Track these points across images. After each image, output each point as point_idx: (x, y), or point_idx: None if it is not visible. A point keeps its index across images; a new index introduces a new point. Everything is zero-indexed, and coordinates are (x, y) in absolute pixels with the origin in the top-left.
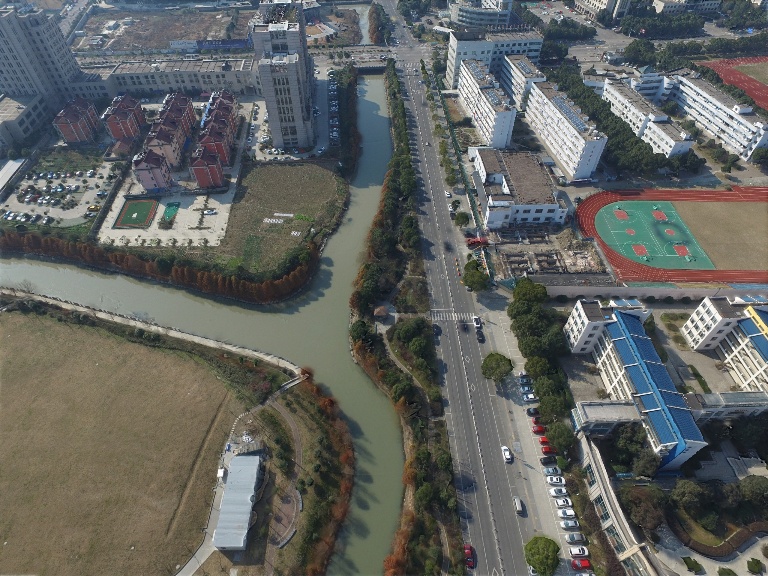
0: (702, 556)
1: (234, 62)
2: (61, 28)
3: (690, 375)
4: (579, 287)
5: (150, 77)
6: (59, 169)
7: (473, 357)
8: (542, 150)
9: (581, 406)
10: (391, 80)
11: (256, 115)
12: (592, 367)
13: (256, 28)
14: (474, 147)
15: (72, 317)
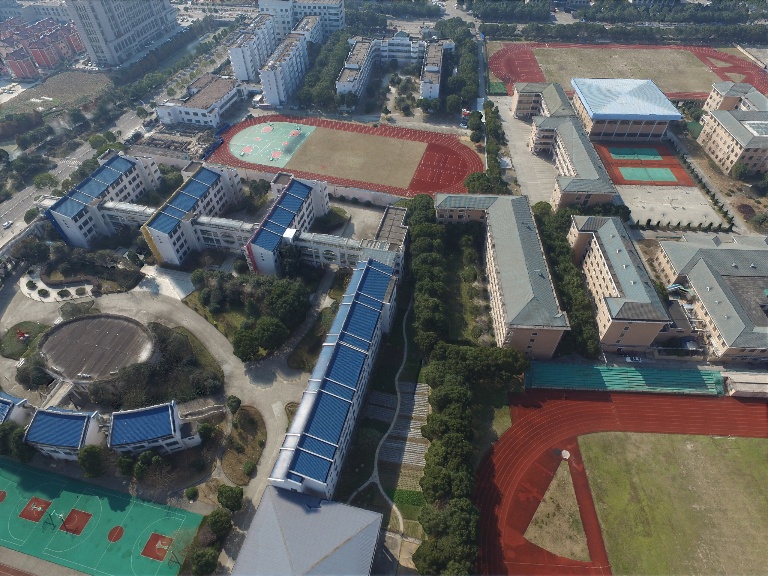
0: (43, 284)
1: None
2: None
3: None
4: (155, 155)
5: (55, 10)
6: None
7: None
8: None
9: (44, 198)
10: None
11: None
12: None
13: None
14: None
15: None
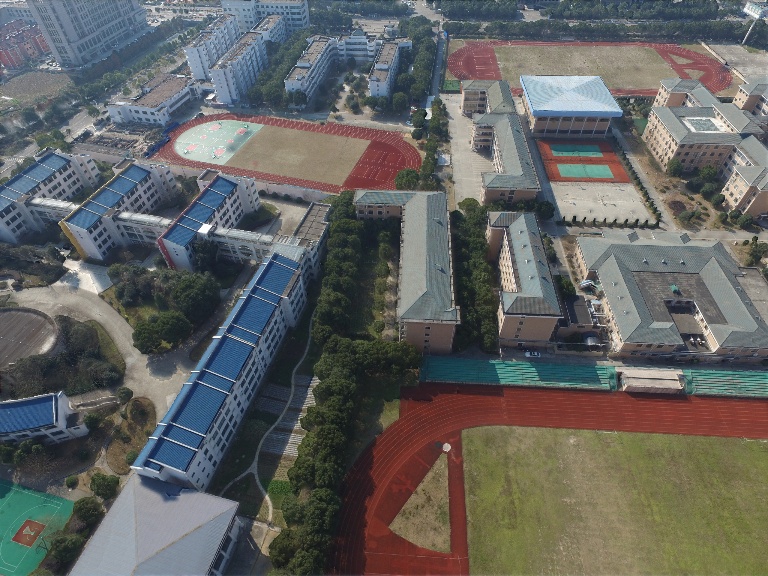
0: None
1: None
2: None
3: None
4: (97, 153)
5: (28, 11)
6: None
7: None
8: None
9: None
10: None
11: None
12: None
13: None
14: None
15: None
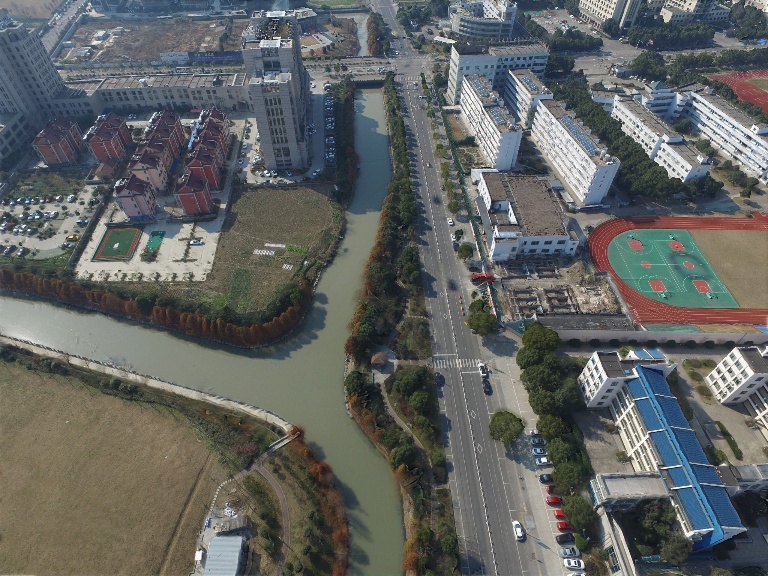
0: None
1: (226, 76)
2: (48, 39)
3: (718, 433)
4: (594, 331)
5: (137, 93)
6: (38, 194)
7: (479, 412)
8: (549, 172)
9: (601, 479)
10: (390, 95)
11: (248, 133)
12: (610, 424)
13: (247, 45)
14: (478, 169)
15: (43, 365)
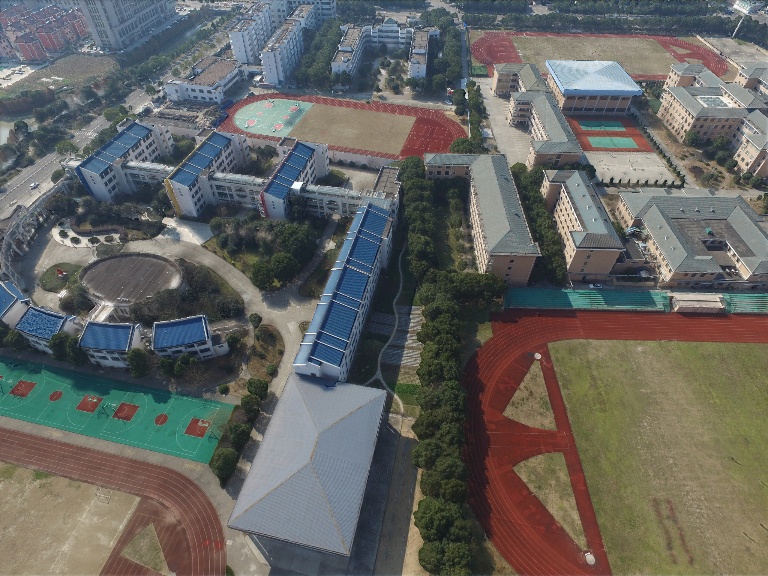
0: (74, 233)
1: None
2: None
3: None
4: None
5: None
6: None
7: None
8: None
9: (69, 159)
10: None
11: None
12: None
13: None
14: None
15: None
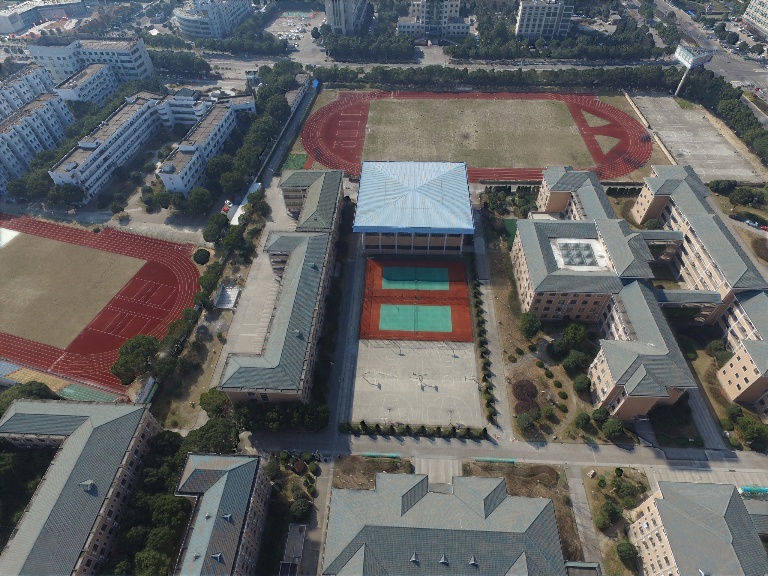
0: None
1: None
2: None
3: None
4: None
5: None
6: None
7: None
8: None
9: None
10: None
11: None
12: None
13: None
14: None
15: None
